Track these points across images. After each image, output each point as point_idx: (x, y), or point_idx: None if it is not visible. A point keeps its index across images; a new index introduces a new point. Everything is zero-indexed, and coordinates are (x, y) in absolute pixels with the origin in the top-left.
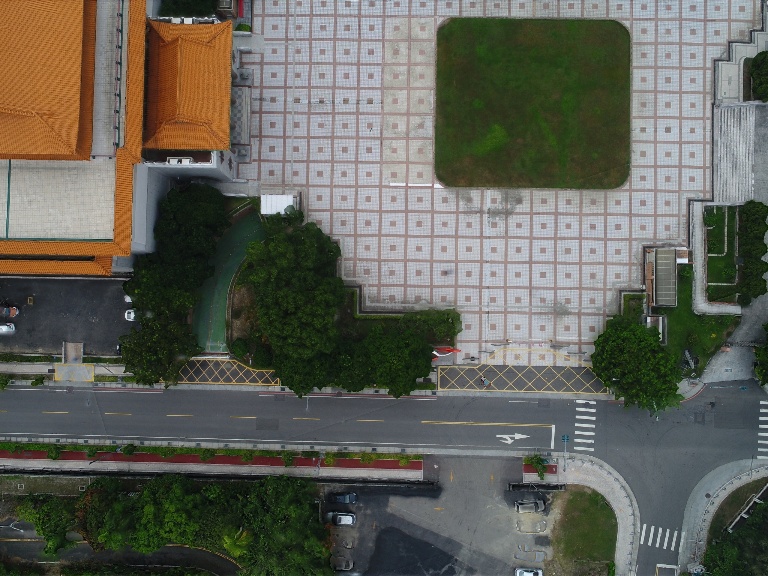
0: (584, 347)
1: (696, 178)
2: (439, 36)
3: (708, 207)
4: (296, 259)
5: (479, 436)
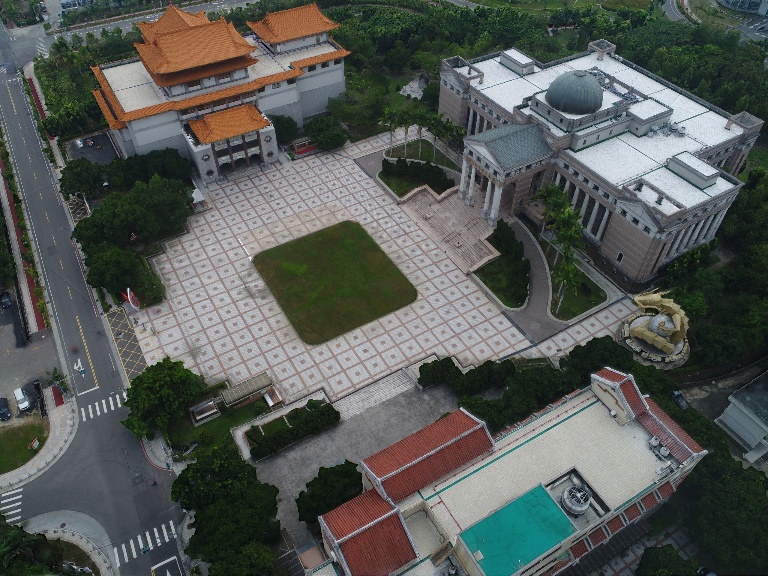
0: None
1: (342, 384)
2: (343, 222)
3: (324, 401)
4: None
5: (75, 349)
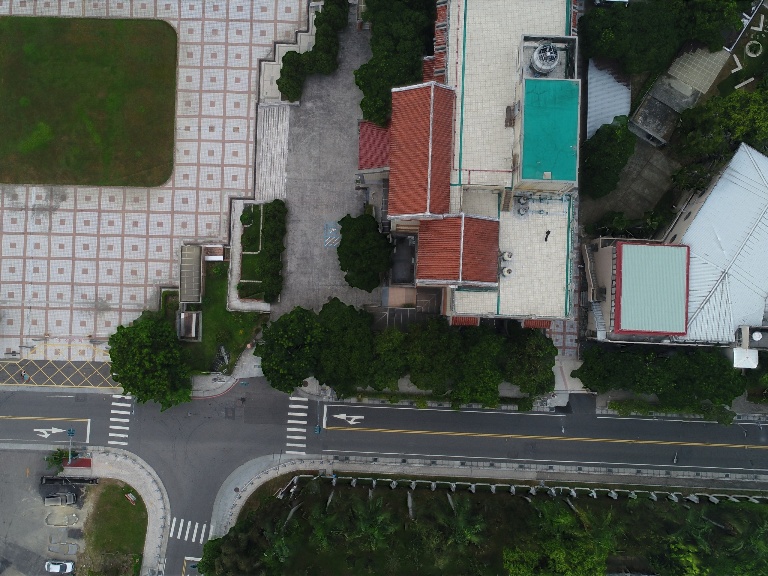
0: None
1: (238, 177)
2: None
3: (248, 205)
4: None
5: (17, 430)
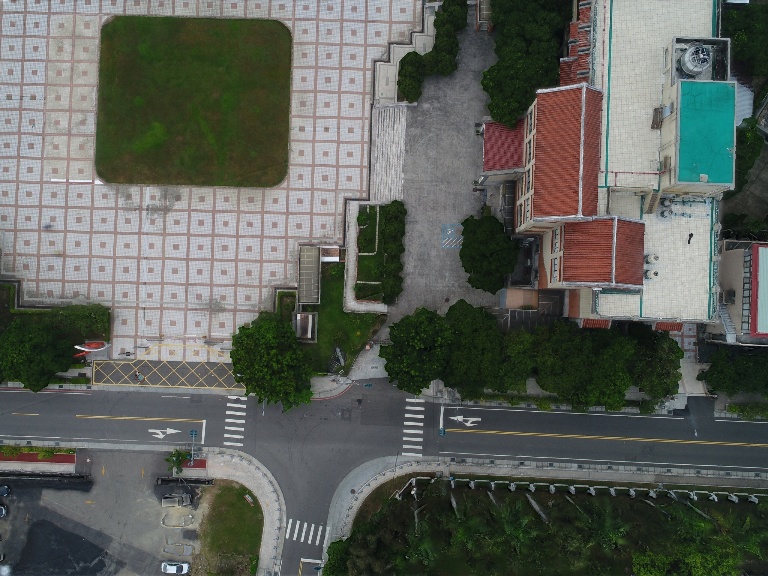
0: None
1: (353, 177)
2: (103, 34)
3: (363, 206)
4: None
5: (131, 430)
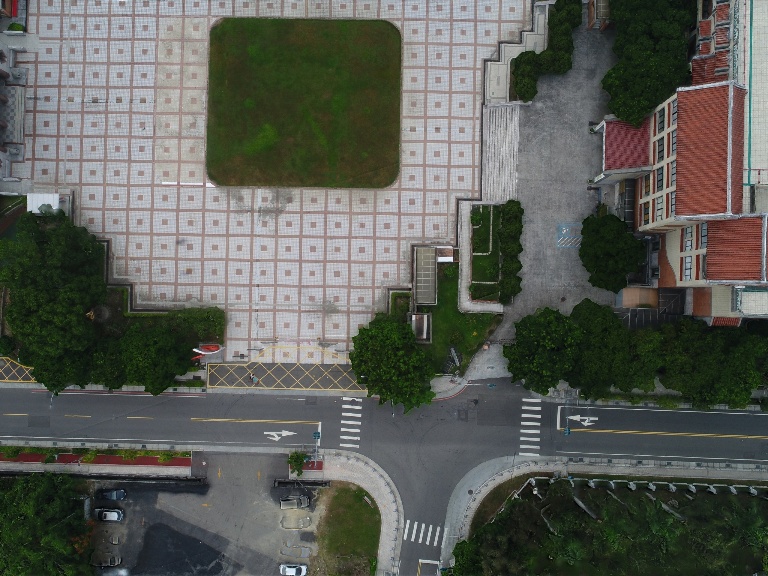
0: (352, 345)
1: (465, 177)
2: (212, 36)
3: (475, 206)
4: (42, 257)
5: (247, 433)
